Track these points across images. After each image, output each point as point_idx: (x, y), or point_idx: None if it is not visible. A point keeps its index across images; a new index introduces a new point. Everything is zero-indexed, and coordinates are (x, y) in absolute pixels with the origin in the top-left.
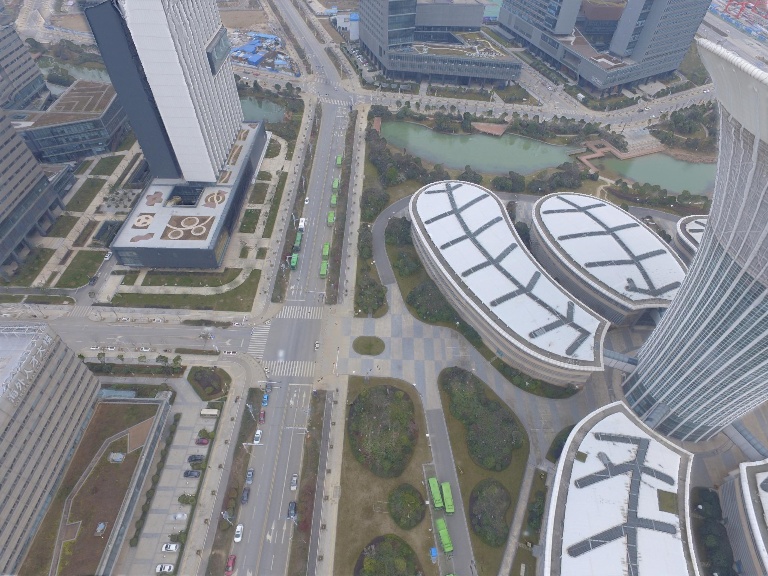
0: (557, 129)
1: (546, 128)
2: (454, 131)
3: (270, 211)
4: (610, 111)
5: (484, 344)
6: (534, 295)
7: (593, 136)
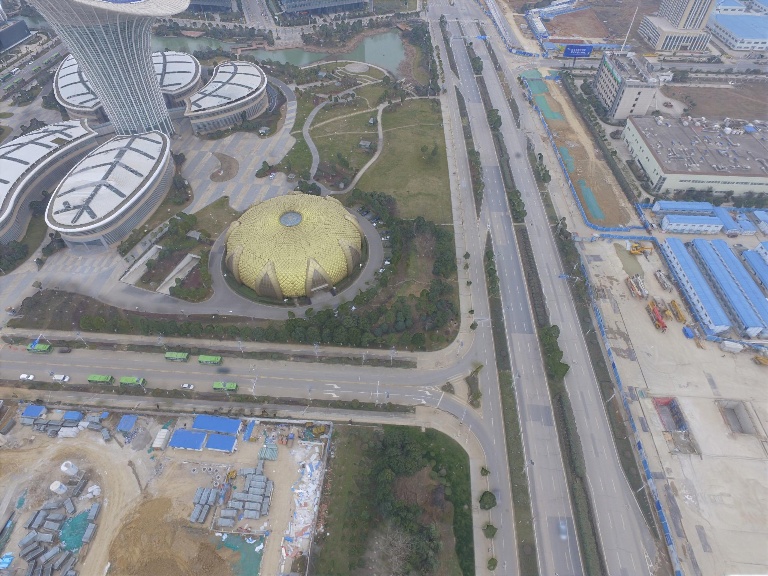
0: (233, 33)
1: (226, 32)
2: (166, 35)
3: (3, 66)
4: (290, 27)
5: (68, 116)
6: (86, 83)
7: (259, 38)
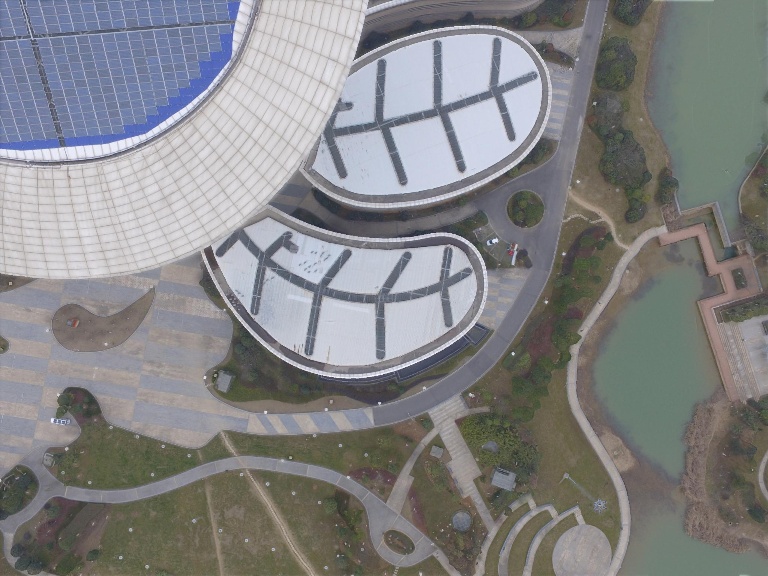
0: None
1: None
2: None
3: None
4: None
5: None
6: None
7: None
